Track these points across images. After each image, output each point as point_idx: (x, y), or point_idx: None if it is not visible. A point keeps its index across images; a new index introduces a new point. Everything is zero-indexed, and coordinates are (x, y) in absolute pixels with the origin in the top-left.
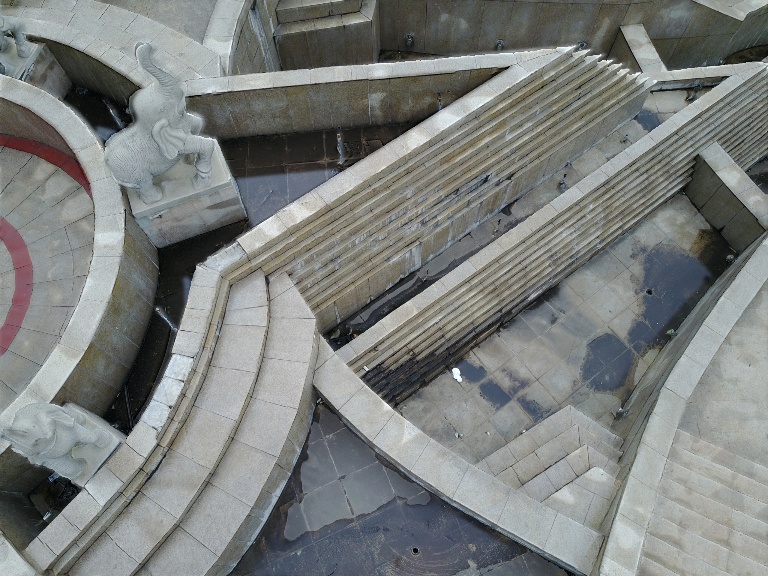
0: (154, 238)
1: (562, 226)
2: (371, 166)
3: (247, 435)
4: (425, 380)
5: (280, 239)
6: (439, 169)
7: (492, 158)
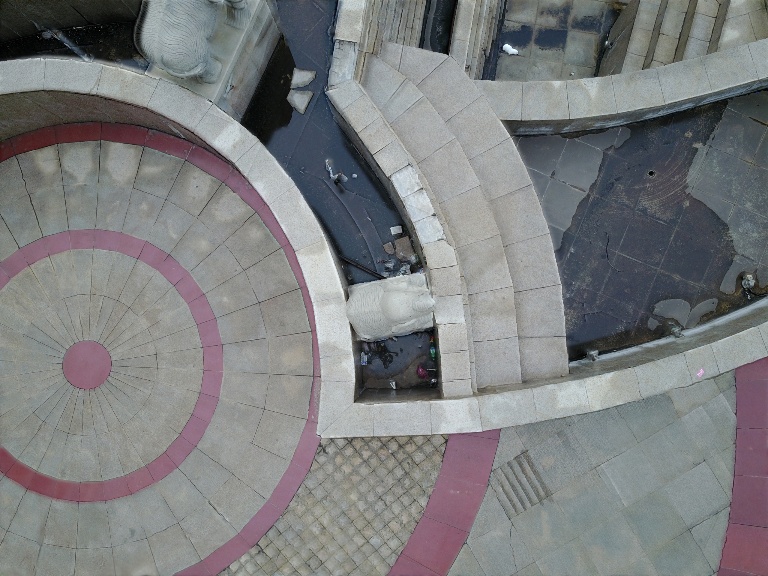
0: None
1: None
2: None
3: (493, 190)
4: None
5: None
6: None
7: None
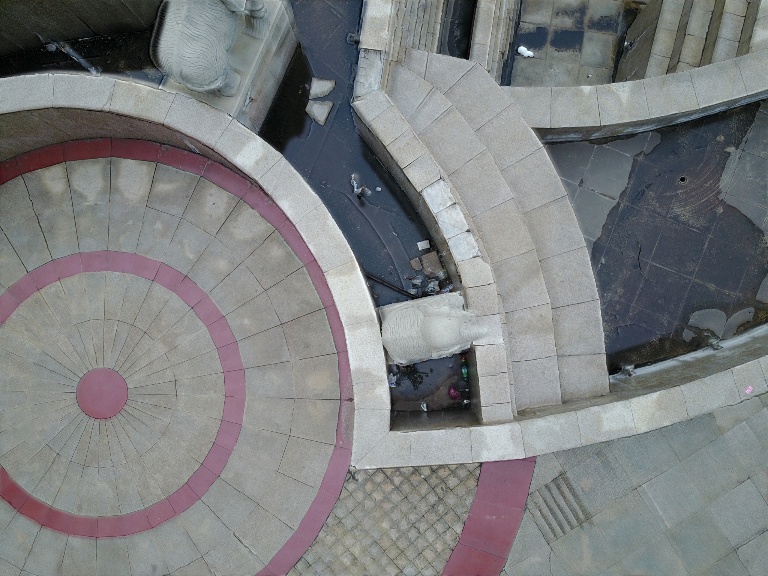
0: None
1: None
2: None
3: (526, 203)
4: None
5: None
6: None
7: None
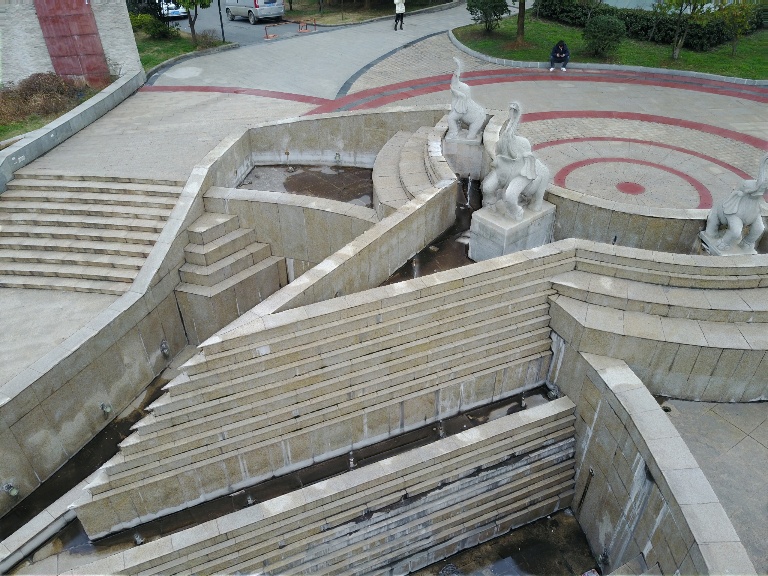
0: None
1: None
2: (373, 232)
3: None
4: None
5: None
6: None
7: None
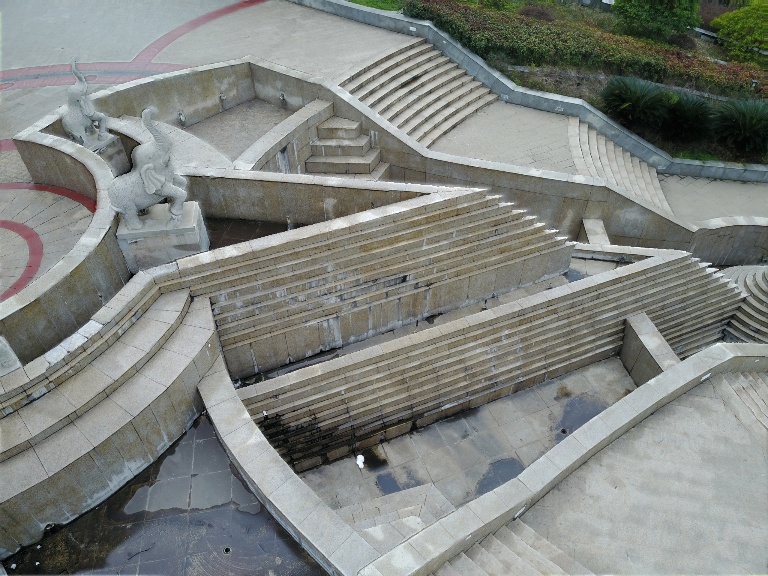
0: (130, 262)
1: (475, 341)
2: (297, 234)
3: (120, 396)
4: (328, 456)
5: (210, 268)
6: (358, 255)
7: (410, 261)
